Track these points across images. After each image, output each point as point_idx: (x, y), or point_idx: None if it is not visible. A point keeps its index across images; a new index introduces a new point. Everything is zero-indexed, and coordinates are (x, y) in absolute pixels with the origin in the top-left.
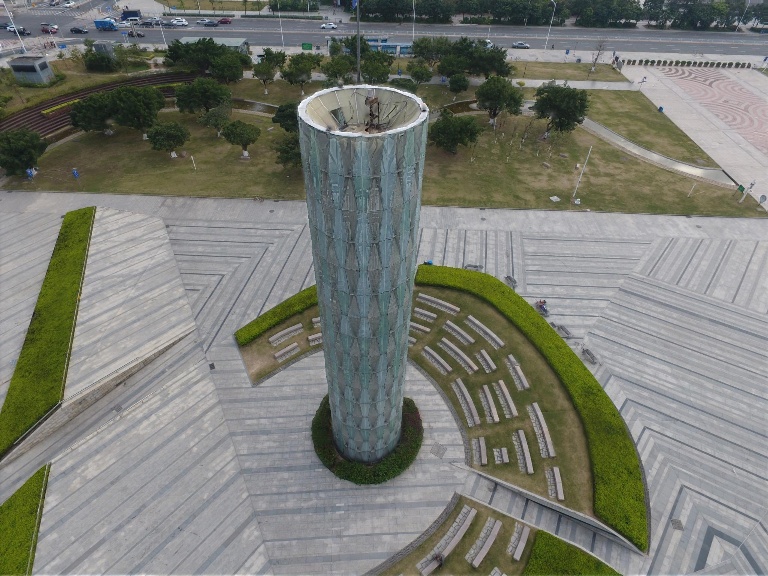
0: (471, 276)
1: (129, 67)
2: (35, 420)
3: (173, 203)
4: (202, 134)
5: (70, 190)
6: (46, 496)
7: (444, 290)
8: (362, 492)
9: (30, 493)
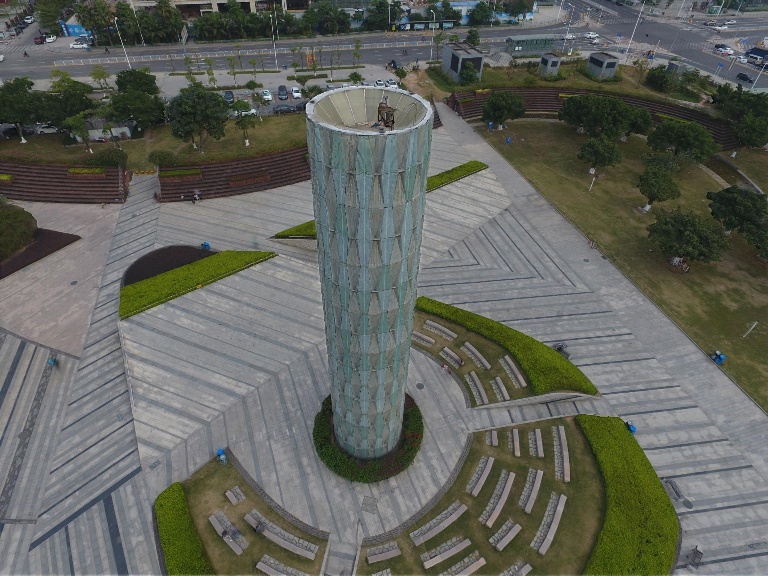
0: (645, 486)
1: (681, 94)
2: (304, 235)
3: (535, 200)
4: (642, 171)
5: (499, 150)
6: (259, 264)
7: (589, 454)
8: (308, 443)
9: (258, 256)
